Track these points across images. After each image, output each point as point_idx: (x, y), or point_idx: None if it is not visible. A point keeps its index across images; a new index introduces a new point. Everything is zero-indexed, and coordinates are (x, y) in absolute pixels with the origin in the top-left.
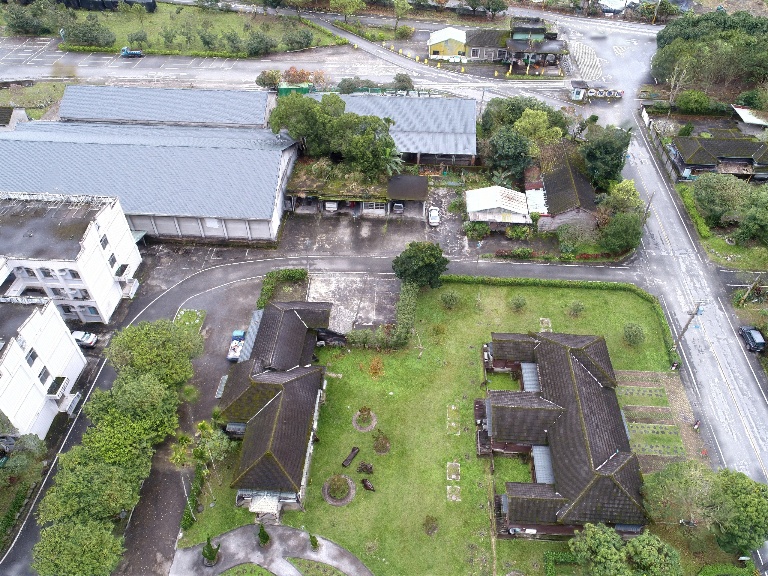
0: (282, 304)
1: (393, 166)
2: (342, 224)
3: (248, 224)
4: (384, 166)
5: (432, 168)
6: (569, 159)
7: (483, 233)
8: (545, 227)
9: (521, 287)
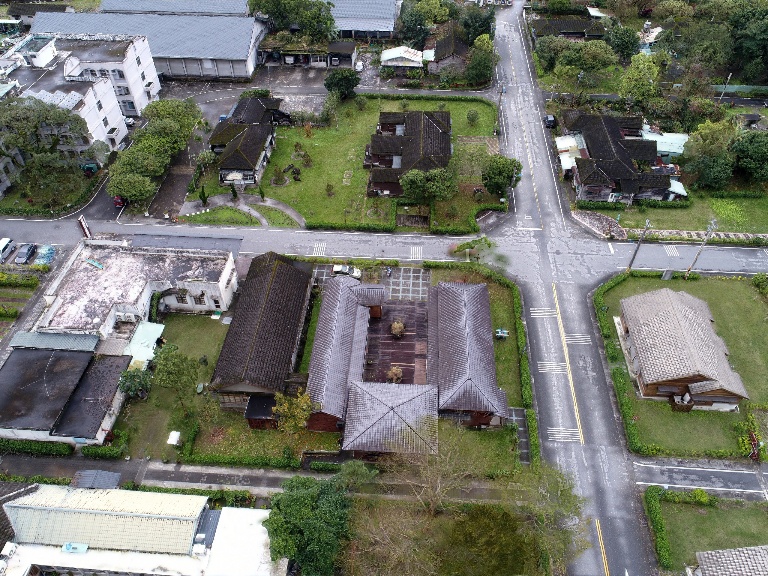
0: None
1: (332, 34)
2: (296, 71)
3: (232, 64)
4: (325, 32)
5: (363, 41)
6: (455, 30)
7: (390, 73)
8: (433, 71)
9: (410, 100)
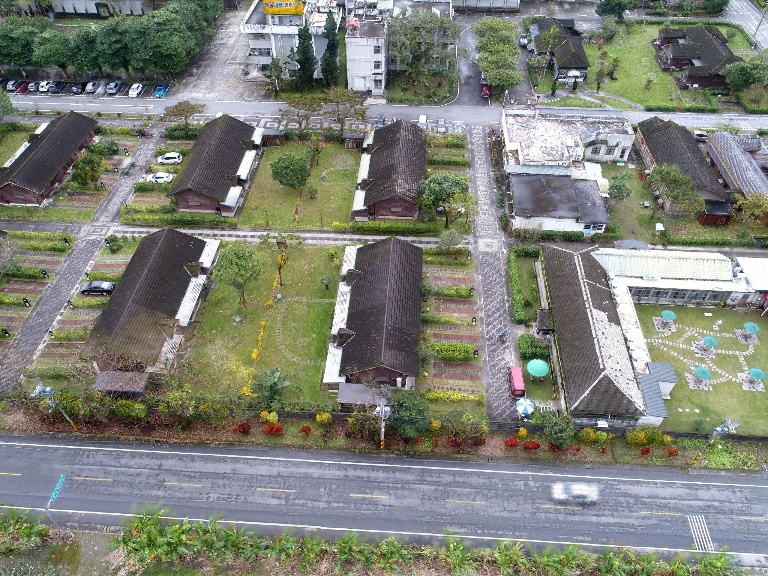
0: None
1: None
2: (552, 4)
3: None
4: None
5: None
6: None
7: (637, 4)
8: (671, 3)
9: None
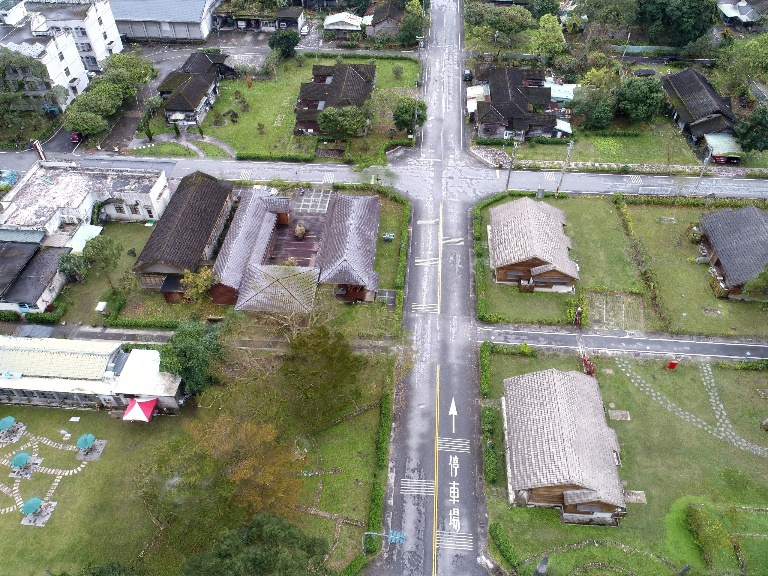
0: None
1: (281, 1)
2: (248, 34)
3: (187, 27)
4: None
5: (311, 9)
6: None
7: (331, 36)
8: (371, 34)
9: (346, 59)
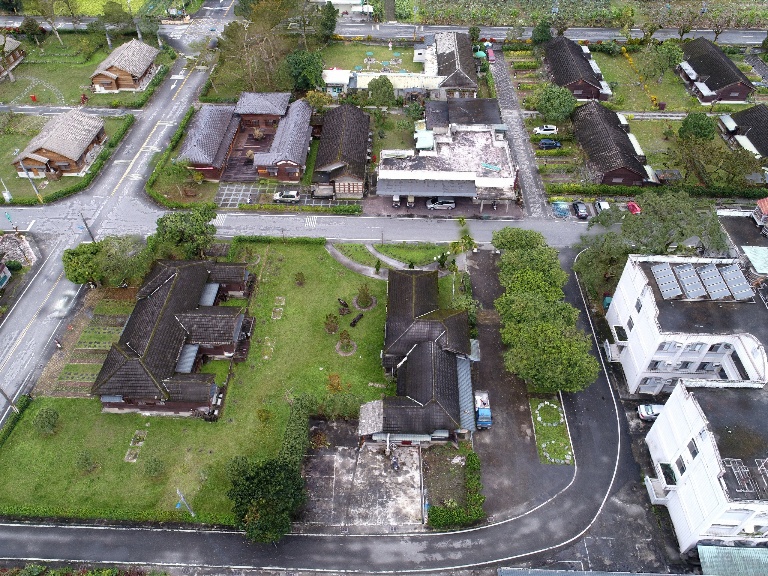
0: (441, 420)
1: None
2: None
3: None
4: None
5: None
6: None
7: None
8: None
9: None
